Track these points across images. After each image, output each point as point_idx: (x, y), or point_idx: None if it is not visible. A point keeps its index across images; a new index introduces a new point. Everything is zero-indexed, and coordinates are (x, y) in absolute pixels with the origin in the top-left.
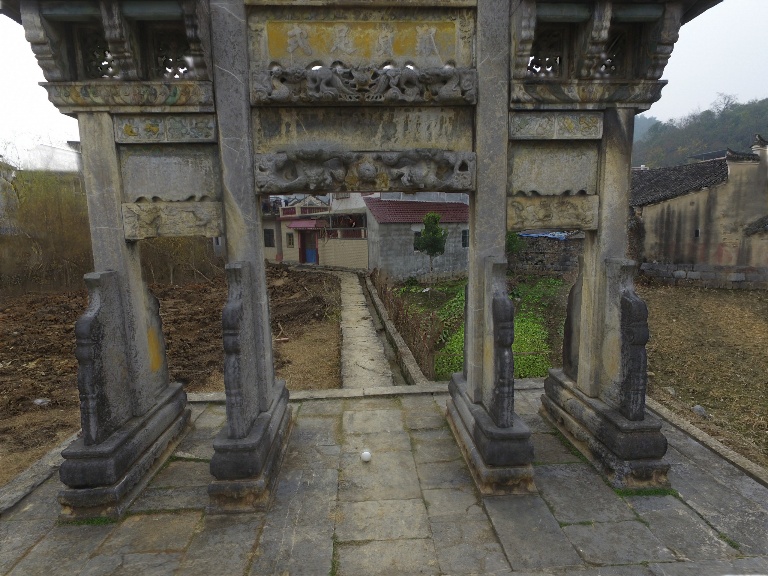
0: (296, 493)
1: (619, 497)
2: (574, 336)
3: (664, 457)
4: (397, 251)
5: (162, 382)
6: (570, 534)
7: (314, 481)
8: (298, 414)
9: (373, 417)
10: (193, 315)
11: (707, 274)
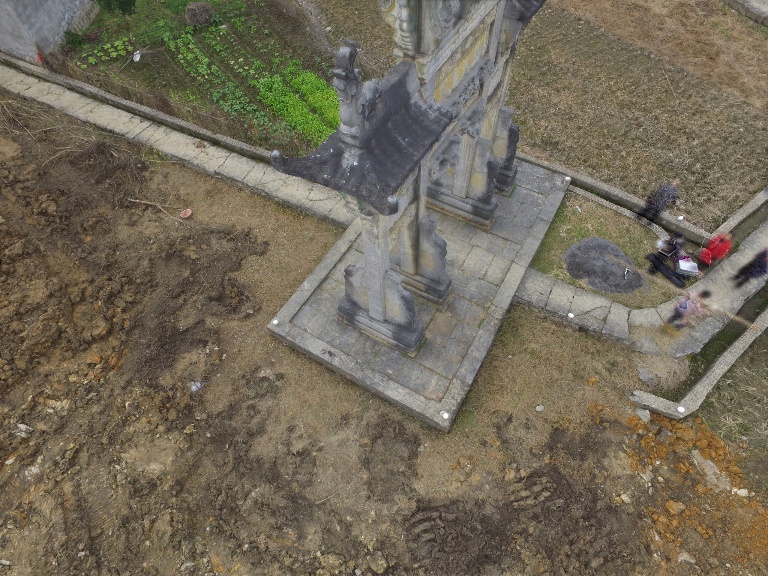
0: None
1: (511, 199)
2: None
3: None
4: (32, 4)
5: None
6: (517, 223)
7: None
8: None
9: None
10: None
11: None
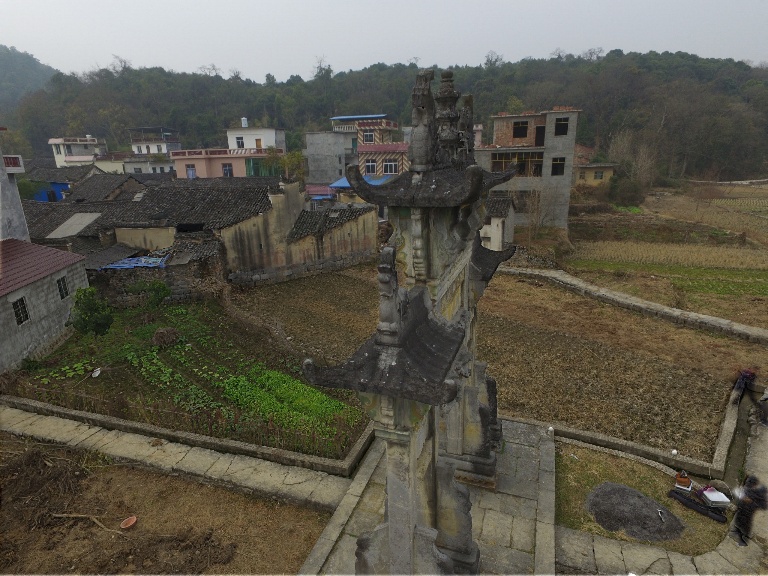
0: None
1: None
2: None
3: None
4: (1, 335)
5: None
6: None
7: None
8: None
9: None
10: None
11: (272, 274)
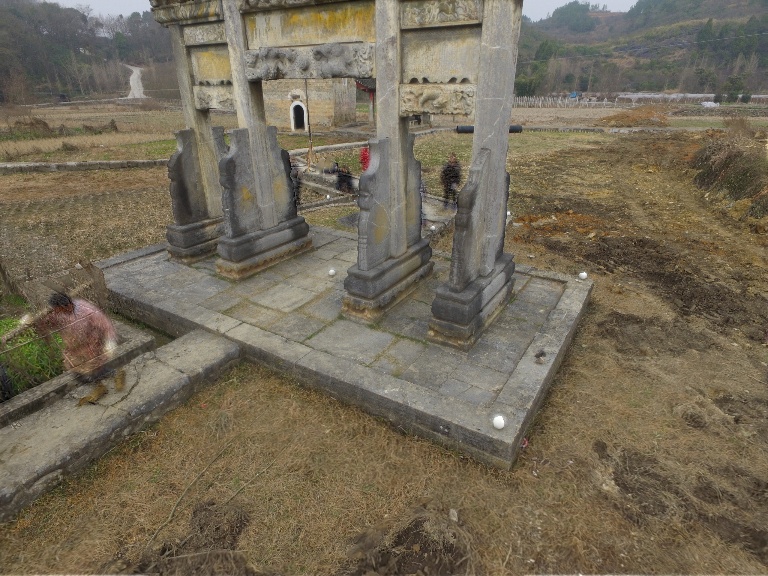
0: None
1: None
2: (191, 191)
3: None
4: None
5: None
6: None
7: None
8: (324, 326)
9: (279, 299)
10: None
11: None
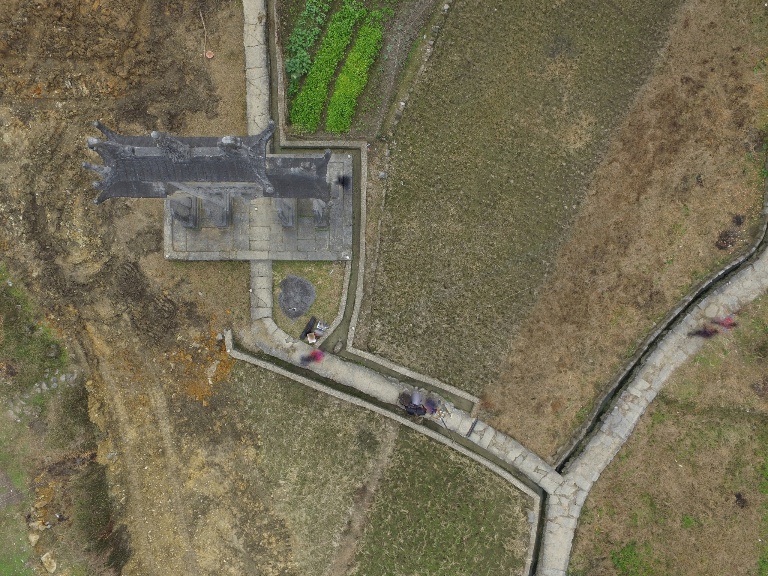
0: (239, 223)
1: (315, 232)
2: None
3: (338, 215)
4: None
5: None
6: (298, 242)
7: (243, 218)
8: None
9: None
10: None
11: None
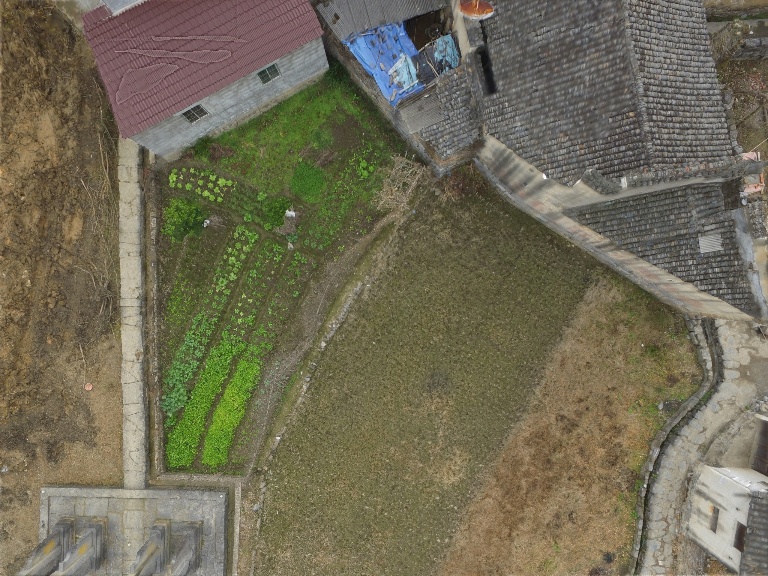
0: (112, 557)
1: None
2: None
3: (209, 552)
4: (168, 136)
5: (57, 537)
6: None
7: (116, 553)
8: (108, 510)
9: (133, 517)
10: (8, 307)
11: None
